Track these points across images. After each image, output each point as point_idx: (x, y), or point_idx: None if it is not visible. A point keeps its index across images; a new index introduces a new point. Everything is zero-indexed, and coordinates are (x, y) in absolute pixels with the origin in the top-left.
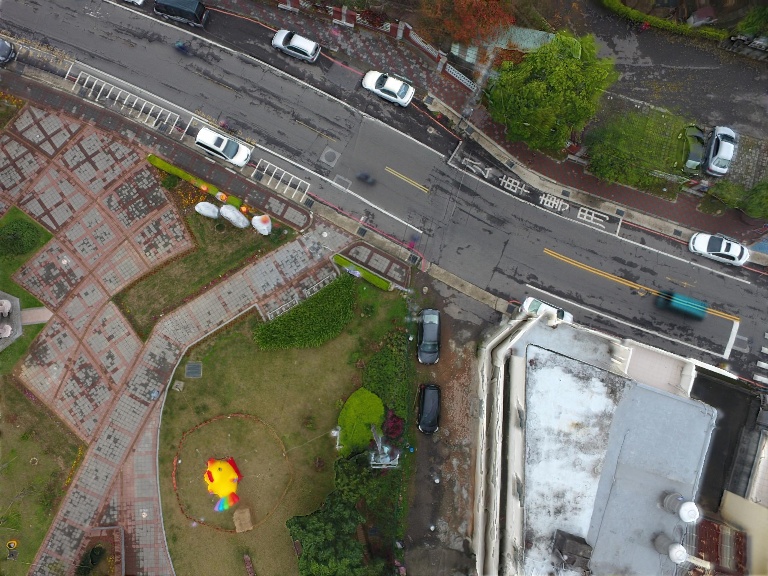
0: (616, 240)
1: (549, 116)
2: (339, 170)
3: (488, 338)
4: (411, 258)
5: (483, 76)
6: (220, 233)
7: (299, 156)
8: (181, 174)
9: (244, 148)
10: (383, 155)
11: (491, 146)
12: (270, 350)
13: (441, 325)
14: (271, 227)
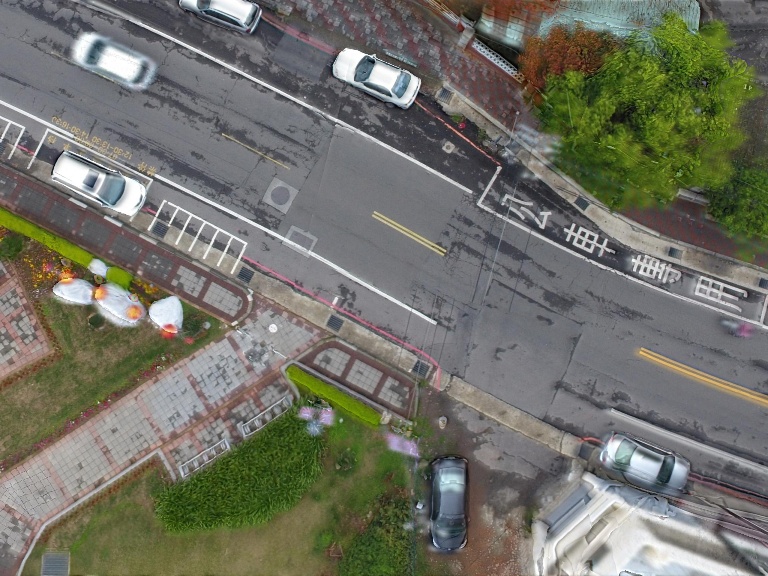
0: (760, 331)
1: (649, 145)
2: (295, 219)
3: (549, 503)
4: (418, 367)
5: (536, 68)
6: (97, 329)
7: (228, 195)
8: (29, 231)
9: (134, 185)
10: (369, 191)
11: (550, 173)
12: (183, 531)
13: (470, 481)
14: (182, 317)
